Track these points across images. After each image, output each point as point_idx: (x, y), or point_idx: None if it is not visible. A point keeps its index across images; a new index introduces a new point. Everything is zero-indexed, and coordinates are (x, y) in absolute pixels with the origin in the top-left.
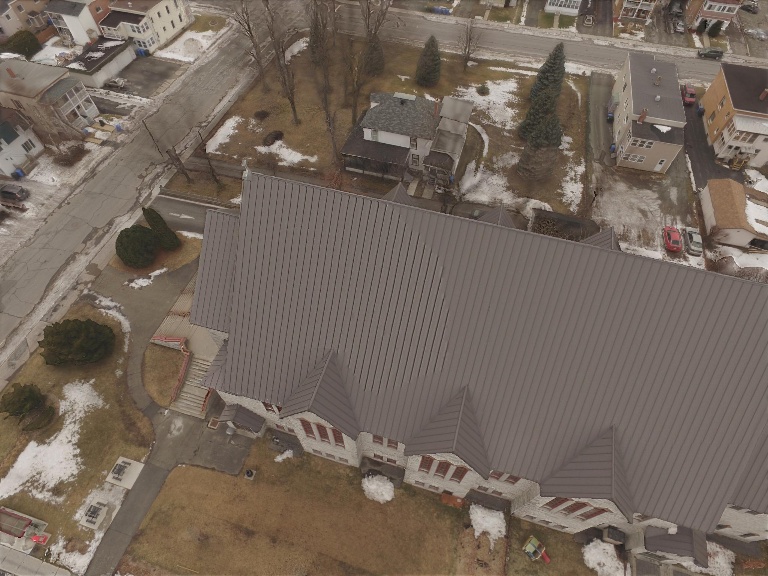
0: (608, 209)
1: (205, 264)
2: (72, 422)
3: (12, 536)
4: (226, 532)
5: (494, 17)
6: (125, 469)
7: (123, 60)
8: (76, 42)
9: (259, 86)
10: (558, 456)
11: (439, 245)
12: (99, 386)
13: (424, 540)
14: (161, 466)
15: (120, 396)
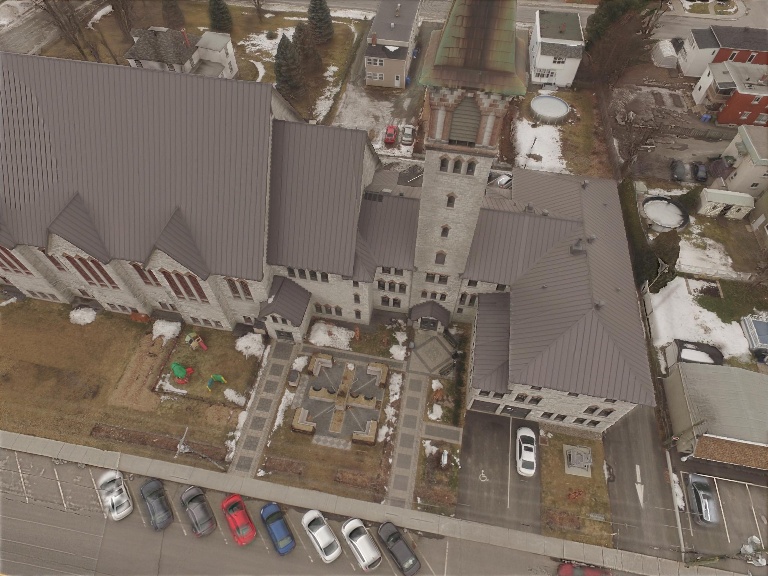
0: (347, 117)
1: None
2: None
3: None
4: None
5: None
6: None
7: None
8: None
9: (64, 41)
10: (150, 238)
11: (29, 80)
12: None
13: (110, 345)
14: None
15: None
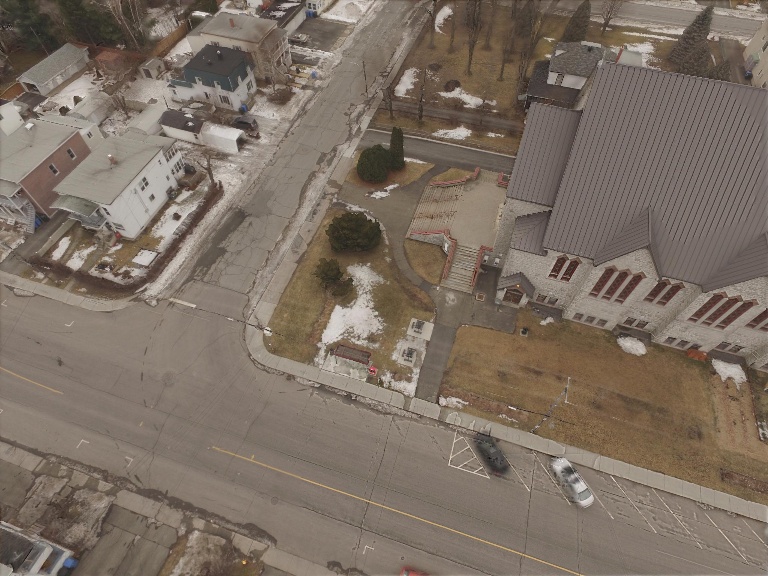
0: None
1: (525, 147)
2: (364, 293)
3: (347, 369)
4: (518, 371)
5: None
6: (423, 325)
7: (298, 20)
8: (251, 4)
9: (424, 44)
10: None
11: (762, 116)
12: (376, 268)
13: (681, 382)
14: (448, 325)
15: (396, 276)
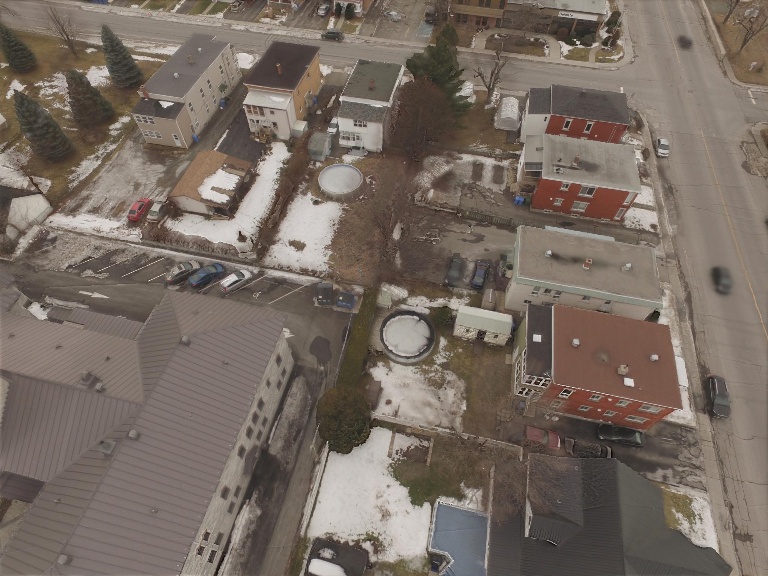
0: (103, 184)
1: None
2: None
3: None
4: None
5: (150, 5)
6: None
7: None
8: None
9: None
10: None
11: None
12: None
13: None
14: None
15: None
